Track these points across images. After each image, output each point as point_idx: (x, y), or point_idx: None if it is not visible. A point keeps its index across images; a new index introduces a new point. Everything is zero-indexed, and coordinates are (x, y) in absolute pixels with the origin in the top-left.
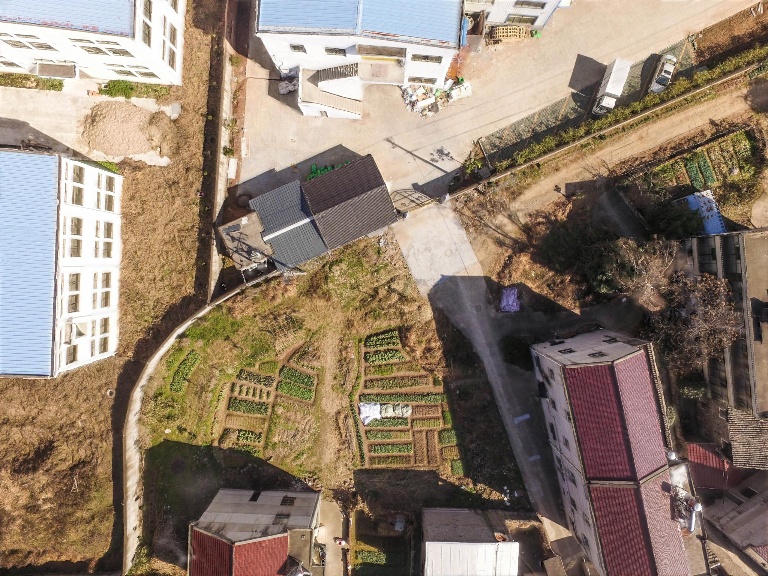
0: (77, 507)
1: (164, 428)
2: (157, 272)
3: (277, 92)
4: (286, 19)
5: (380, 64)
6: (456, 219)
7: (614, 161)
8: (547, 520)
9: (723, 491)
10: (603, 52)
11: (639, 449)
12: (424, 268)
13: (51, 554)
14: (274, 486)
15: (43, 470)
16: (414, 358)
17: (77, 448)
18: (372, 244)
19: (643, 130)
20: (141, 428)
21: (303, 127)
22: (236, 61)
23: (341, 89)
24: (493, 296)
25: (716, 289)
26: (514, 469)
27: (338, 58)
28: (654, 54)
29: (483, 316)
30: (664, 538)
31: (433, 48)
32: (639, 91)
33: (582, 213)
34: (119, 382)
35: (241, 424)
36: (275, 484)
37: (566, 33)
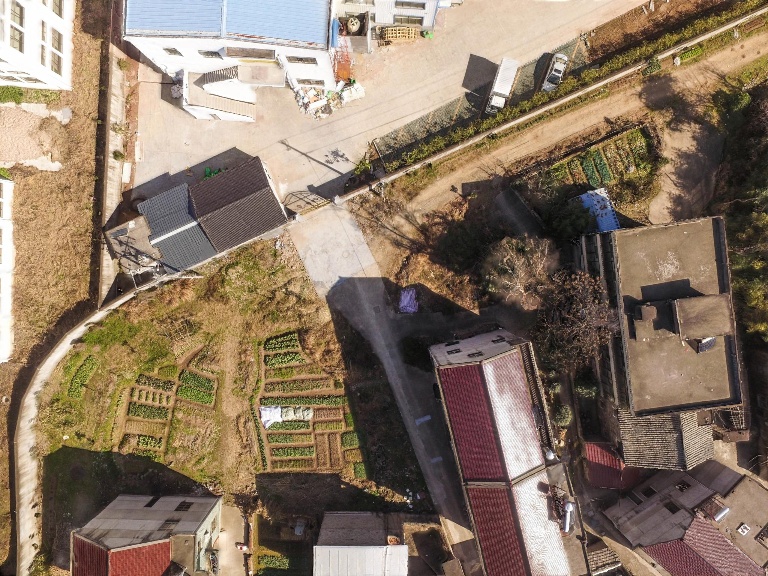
0: None
1: (62, 434)
2: (51, 277)
3: (170, 96)
4: (152, 22)
5: (260, 66)
6: (352, 220)
7: (510, 160)
8: (451, 522)
9: (627, 491)
10: (496, 52)
11: (512, 449)
12: (321, 270)
13: None
14: (175, 491)
15: None
16: (314, 360)
17: None
18: (268, 247)
19: (538, 129)
20: (38, 435)
21: (197, 130)
22: (124, 65)
23: (228, 92)
24: (392, 297)
25: (590, 287)
26: (416, 471)
27: (216, 61)
28: (547, 53)
29: (382, 317)
30: (541, 539)
31: (301, 49)
32: (533, 90)
33: (478, 213)
34: (15, 388)
35: (141, 429)
36: (176, 489)
37: (458, 33)
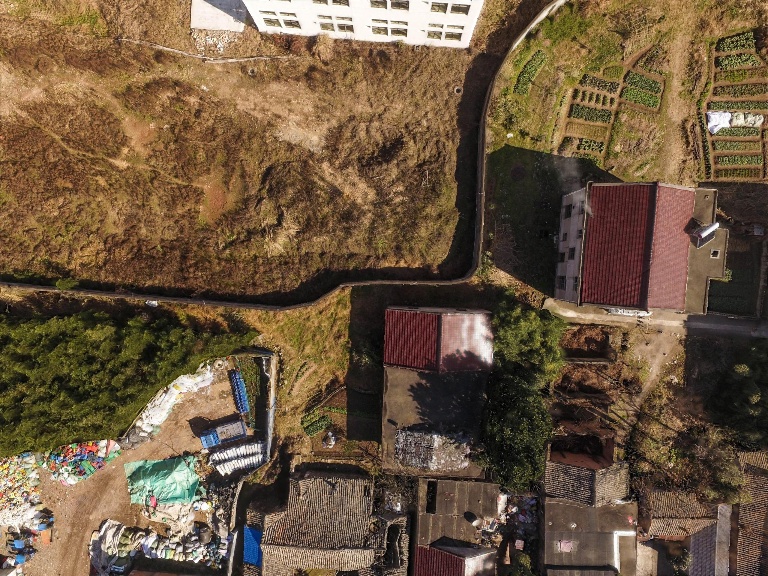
0: (428, 201)
1: (506, 132)
2: None
3: None
4: None
5: None
6: None
7: None
8: None
9: None
10: None
11: None
12: None
13: (391, 258)
14: None
15: (397, 160)
16: None
17: (423, 147)
18: None
19: None
20: None
21: None
22: None
23: None
24: None
25: None
26: None
27: None
28: None
29: None
30: None
31: None
32: None
33: None
34: (466, 79)
35: (582, 132)
36: None
37: None
